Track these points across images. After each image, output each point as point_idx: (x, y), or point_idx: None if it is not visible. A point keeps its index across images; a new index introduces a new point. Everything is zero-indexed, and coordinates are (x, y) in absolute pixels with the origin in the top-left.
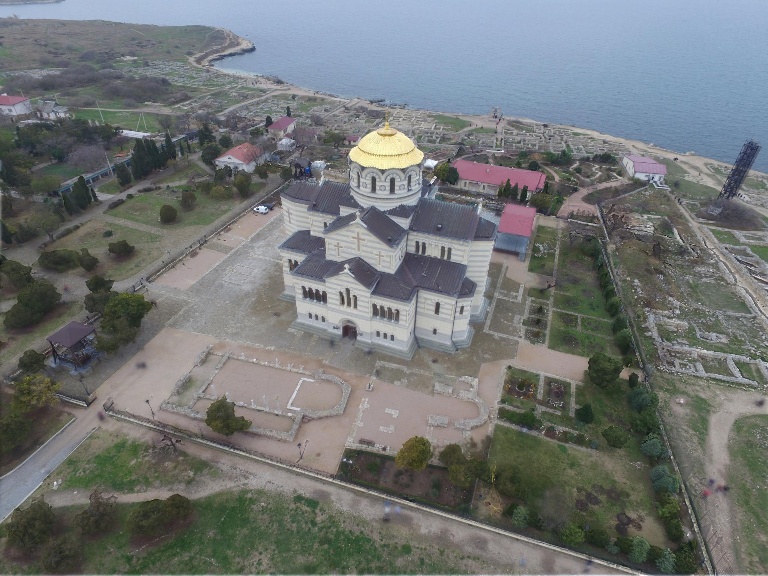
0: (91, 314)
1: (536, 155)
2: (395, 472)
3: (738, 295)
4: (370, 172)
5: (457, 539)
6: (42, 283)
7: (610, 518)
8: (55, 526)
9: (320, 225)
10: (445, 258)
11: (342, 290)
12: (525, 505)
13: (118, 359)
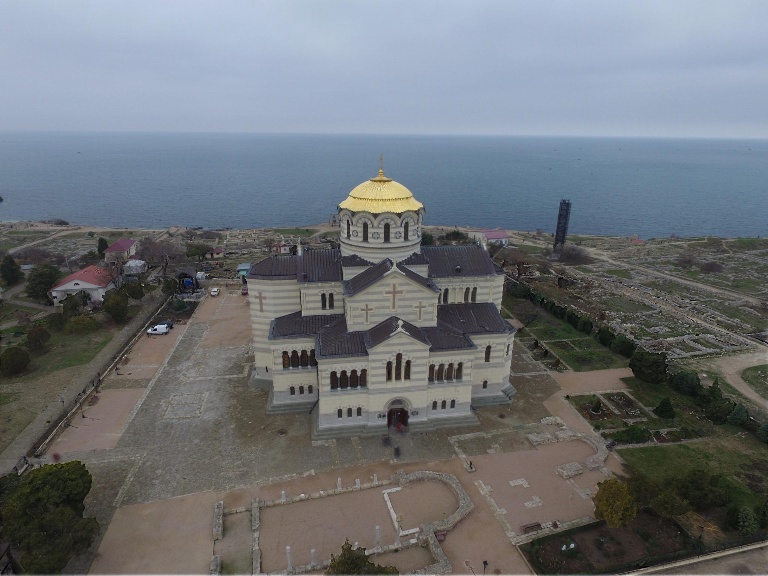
0: None
1: None
2: (594, 544)
3: (636, 300)
4: (384, 218)
5: None
6: None
7: None
8: None
9: (316, 299)
10: (470, 301)
11: (392, 358)
12: (725, 512)
13: None
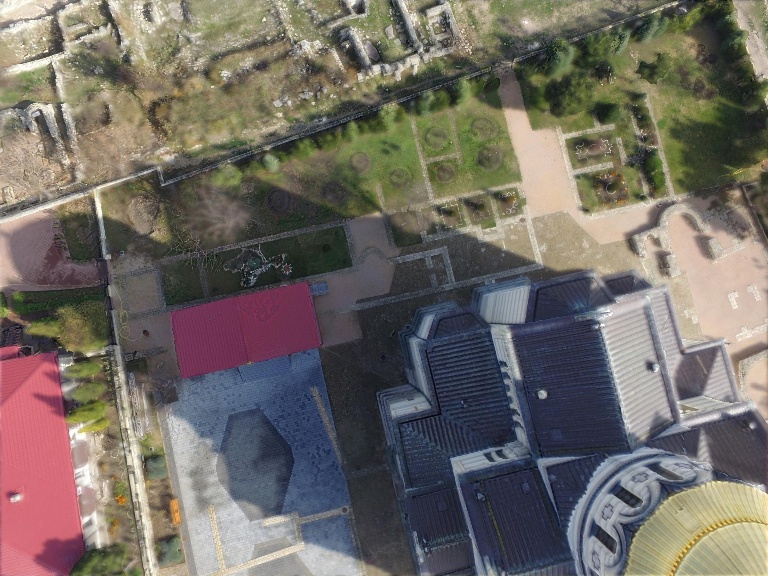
0: None
1: None
2: None
3: None
4: None
5: None
6: None
7: (708, 69)
8: None
9: None
10: None
11: None
12: (744, 137)
13: None
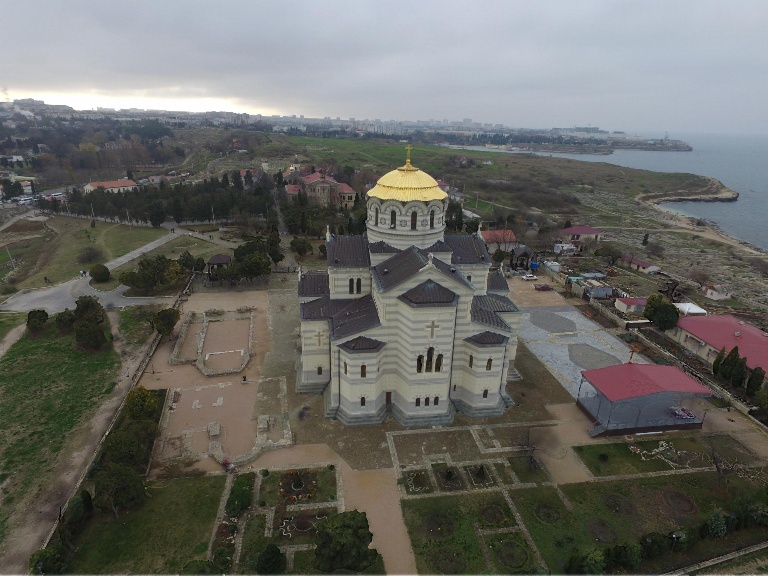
0: None
1: None
2: None
3: None
4: None
5: (63, 477)
6: (260, 242)
7: None
8: None
9: None
10: None
11: None
12: (103, 523)
13: (227, 289)
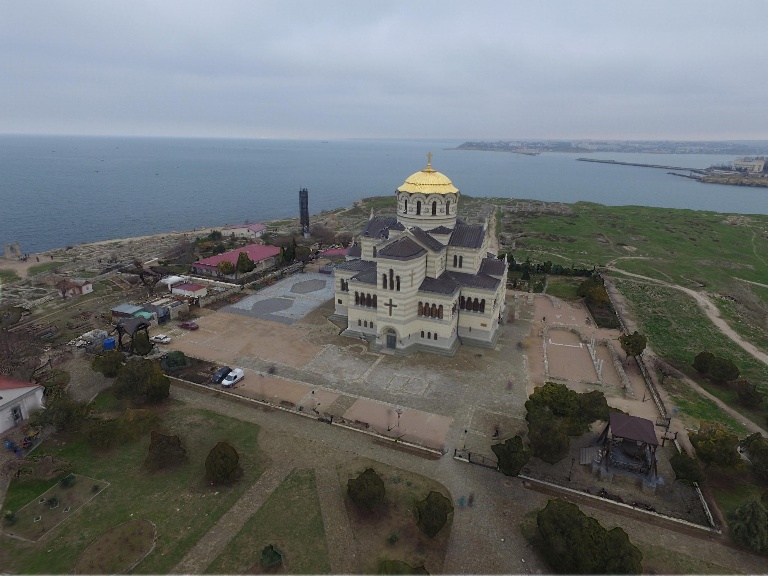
0: (541, 496)
1: (206, 243)
2: (601, 316)
3: None
4: (456, 196)
5: (623, 306)
6: (558, 505)
7: None
8: None
9: None
10: None
11: None
12: None
13: None
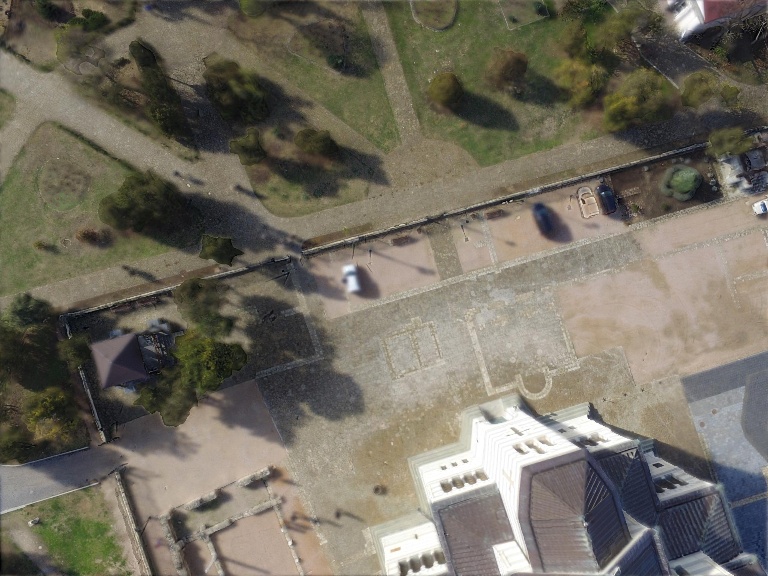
0: (202, 263)
1: None
2: None
3: None
4: None
5: None
6: (152, 194)
7: None
8: (9, 570)
9: None
10: None
11: None
12: None
13: None
